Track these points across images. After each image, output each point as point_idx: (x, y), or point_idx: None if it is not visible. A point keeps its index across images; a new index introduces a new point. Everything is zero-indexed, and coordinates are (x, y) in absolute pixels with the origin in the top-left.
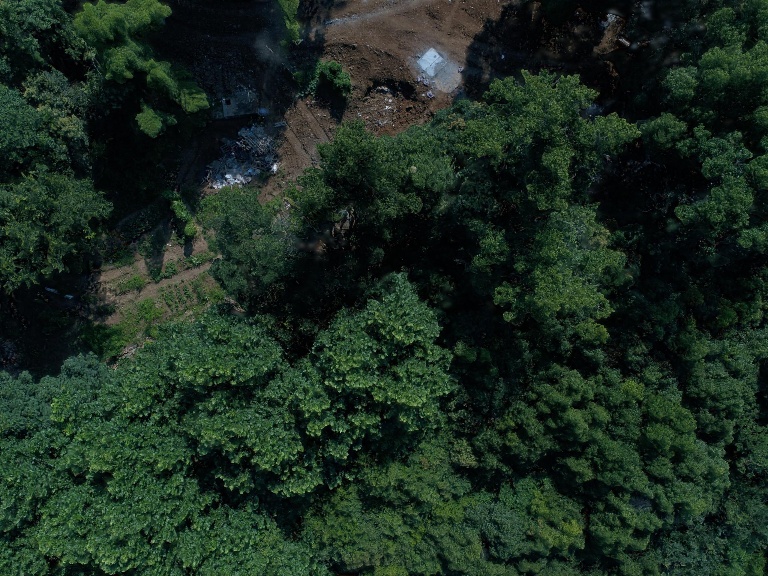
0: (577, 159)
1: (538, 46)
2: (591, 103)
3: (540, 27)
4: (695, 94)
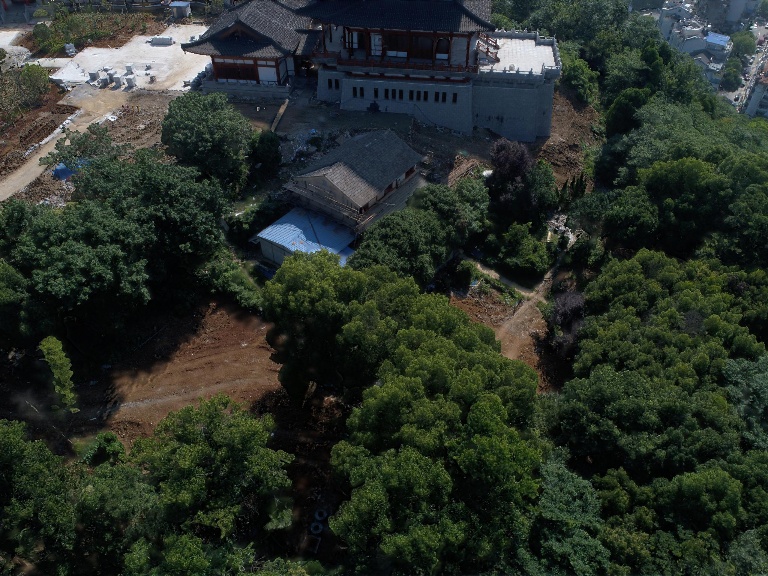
0: (212, 456)
1: (306, 427)
2: (225, 406)
3: (309, 412)
4: (359, 421)
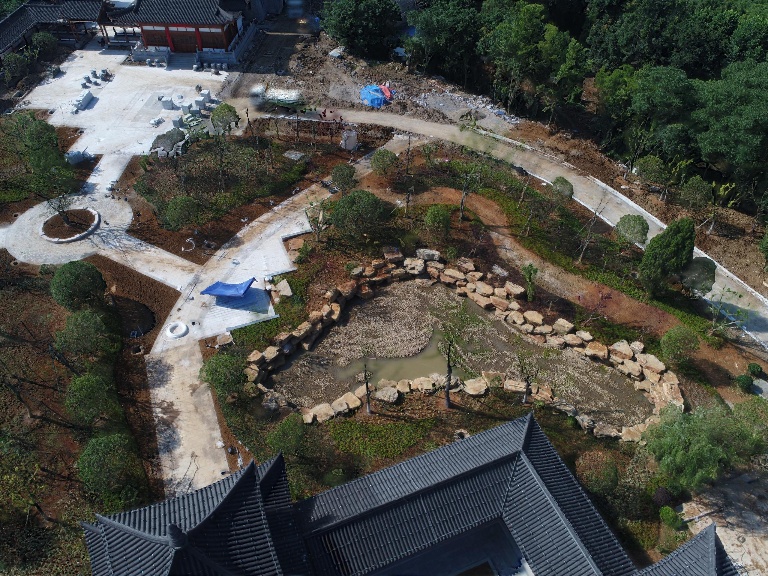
0: None
1: None
2: None
3: None
4: None
